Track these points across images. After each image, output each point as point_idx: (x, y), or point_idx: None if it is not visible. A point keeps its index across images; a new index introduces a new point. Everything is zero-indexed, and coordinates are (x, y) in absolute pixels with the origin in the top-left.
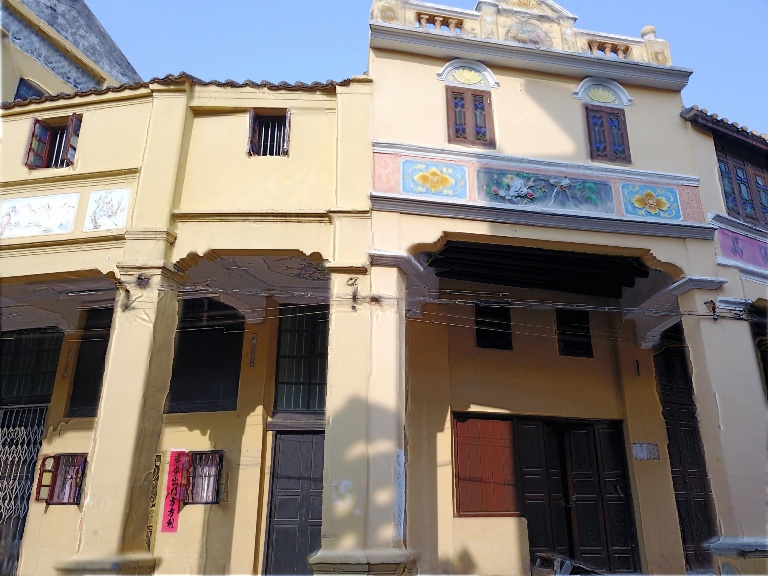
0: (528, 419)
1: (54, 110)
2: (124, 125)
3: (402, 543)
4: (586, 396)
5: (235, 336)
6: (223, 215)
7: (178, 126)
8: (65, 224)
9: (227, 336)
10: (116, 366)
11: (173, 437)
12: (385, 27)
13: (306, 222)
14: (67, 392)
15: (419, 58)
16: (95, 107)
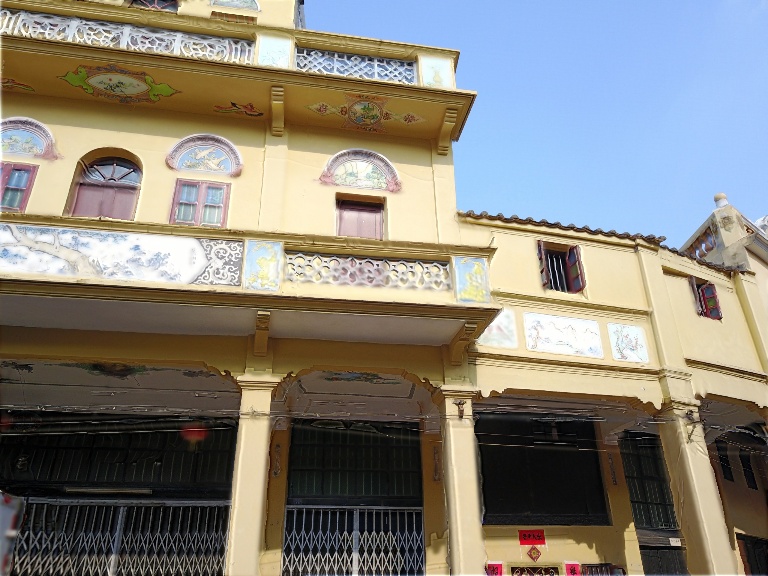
0: (747, 539)
1: (547, 235)
2: (617, 268)
3: None
4: (764, 521)
5: (590, 454)
6: (708, 365)
7: (663, 281)
8: (595, 349)
9: (583, 453)
10: (700, 493)
11: (563, 549)
12: (763, 238)
13: (753, 380)
14: None
15: (761, 261)
16: (581, 242)
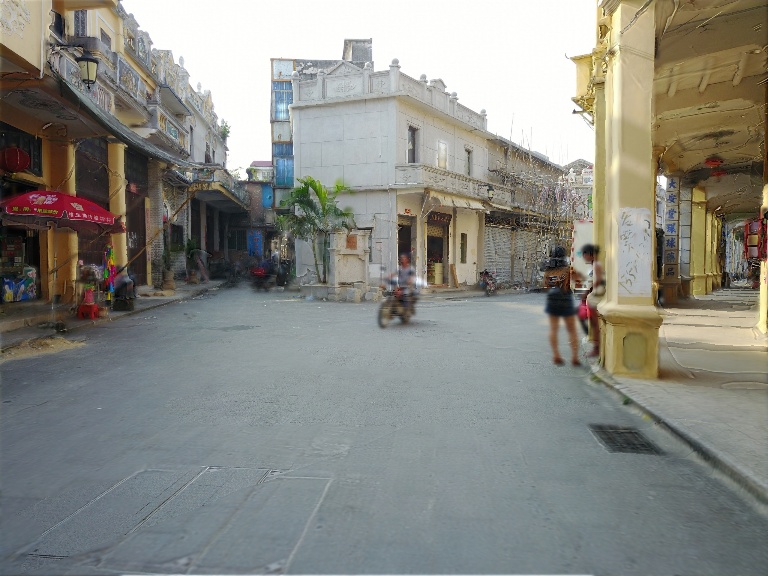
0: None
1: None
2: None
3: (640, 301)
4: None
5: None
6: None
7: None
8: None
9: None
10: None
11: None
12: None
13: None
14: (764, 164)
15: None
16: None
